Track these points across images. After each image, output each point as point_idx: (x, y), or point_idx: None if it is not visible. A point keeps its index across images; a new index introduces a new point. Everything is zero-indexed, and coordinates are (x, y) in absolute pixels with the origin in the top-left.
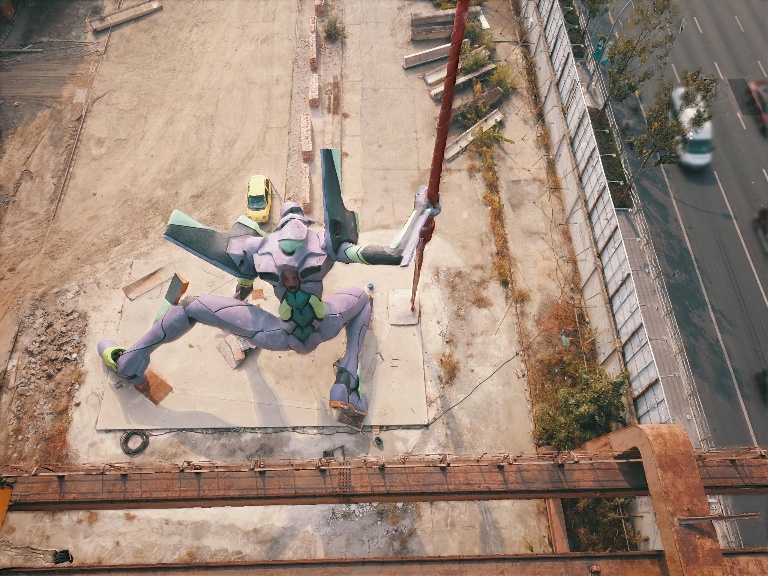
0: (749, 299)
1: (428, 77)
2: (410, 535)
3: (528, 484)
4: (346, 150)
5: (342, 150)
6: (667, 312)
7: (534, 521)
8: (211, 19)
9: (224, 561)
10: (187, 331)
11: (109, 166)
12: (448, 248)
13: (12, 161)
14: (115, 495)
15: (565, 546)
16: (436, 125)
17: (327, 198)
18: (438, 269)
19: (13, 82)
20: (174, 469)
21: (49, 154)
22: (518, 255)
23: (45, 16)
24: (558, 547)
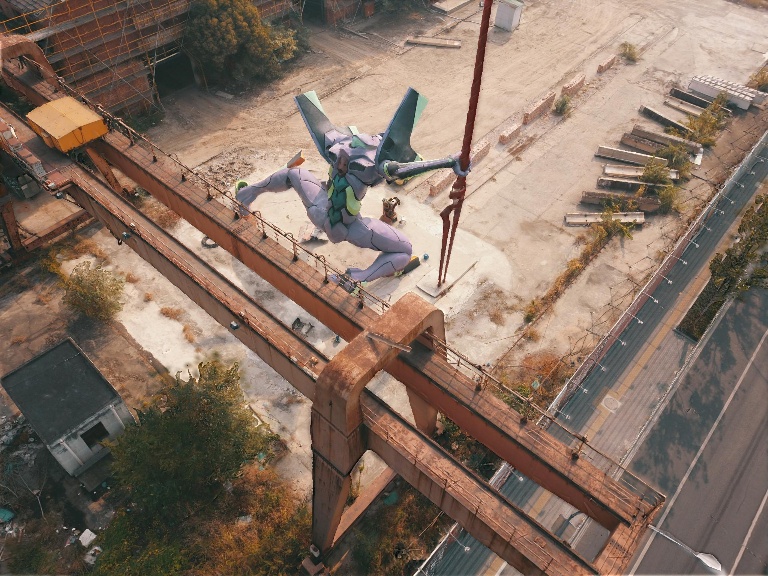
0: (750, 478)
1: (608, 168)
2: (298, 402)
3: (330, 300)
4: (497, 178)
5: (494, 176)
6: (650, 429)
7: (386, 466)
8: (485, 66)
9: (189, 327)
10: (283, 189)
11: (343, 109)
12: (508, 273)
13: (297, 81)
14: (142, 165)
15: (383, 483)
16: (581, 198)
17: (395, 122)
18: (487, 280)
19: (337, 46)
20: (176, 173)
21: (318, 87)
22: (559, 310)
23: (388, 23)
24: (378, 479)
